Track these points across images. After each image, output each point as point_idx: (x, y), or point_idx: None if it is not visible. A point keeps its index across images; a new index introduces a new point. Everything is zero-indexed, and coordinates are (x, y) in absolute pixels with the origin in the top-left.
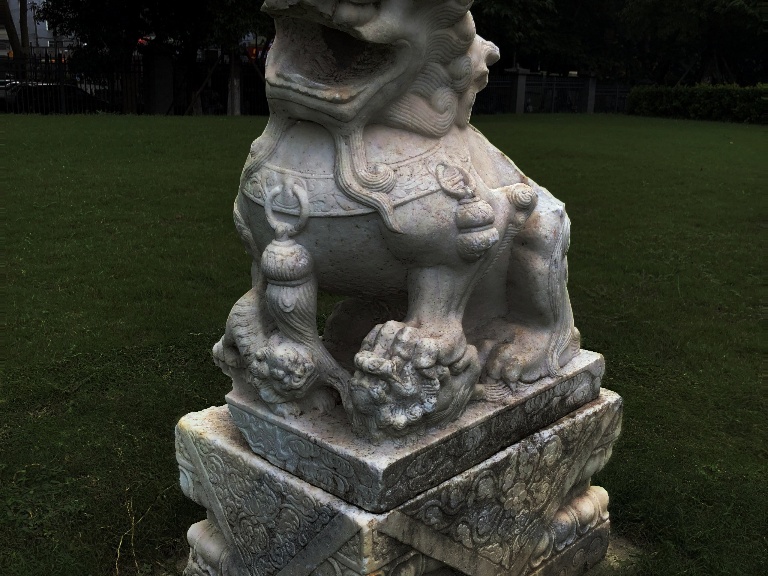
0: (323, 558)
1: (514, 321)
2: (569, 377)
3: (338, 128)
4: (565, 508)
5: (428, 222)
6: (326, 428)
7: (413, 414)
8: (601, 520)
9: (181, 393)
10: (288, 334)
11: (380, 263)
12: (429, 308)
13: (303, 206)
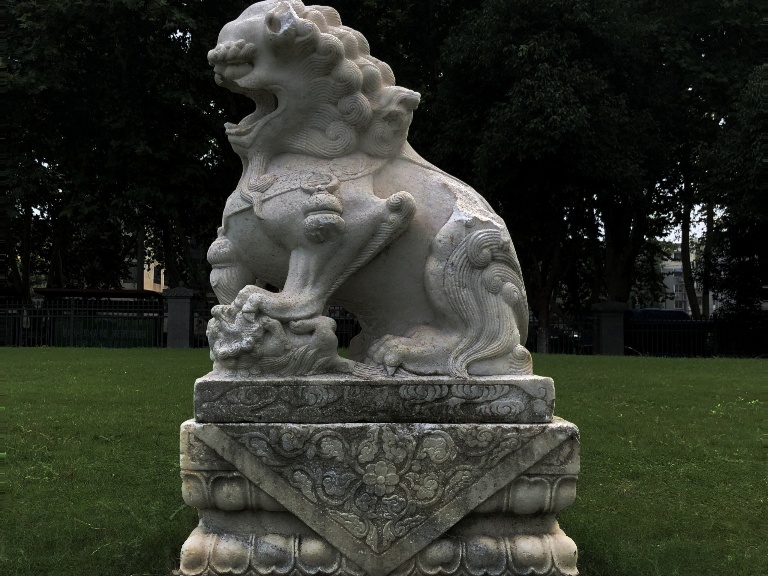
0: None
1: (431, 325)
2: (479, 383)
3: (247, 154)
4: (500, 538)
5: (281, 210)
6: None
7: (231, 347)
8: (560, 573)
9: None
10: None
11: (269, 250)
12: (290, 281)
13: (225, 210)
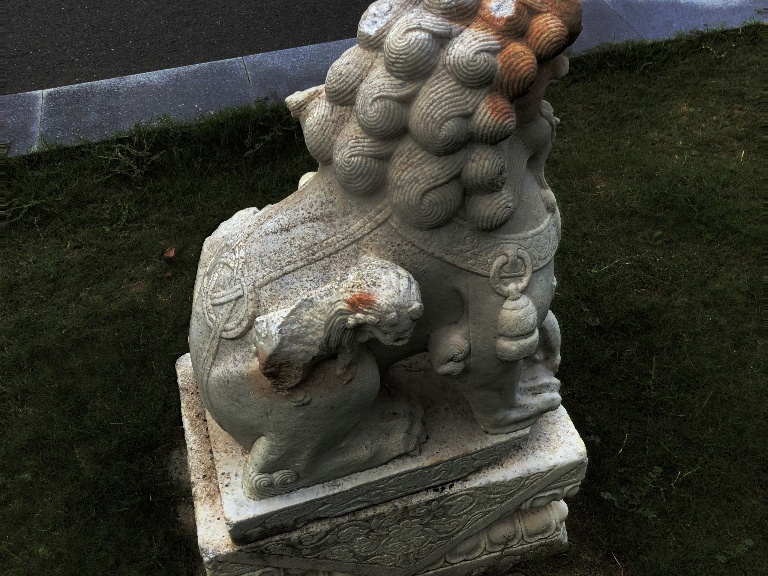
0: None
1: None
2: None
3: None
4: None
5: None
6: None
7: None
8: None
9: None
10: None
11: None
12: None
13: None
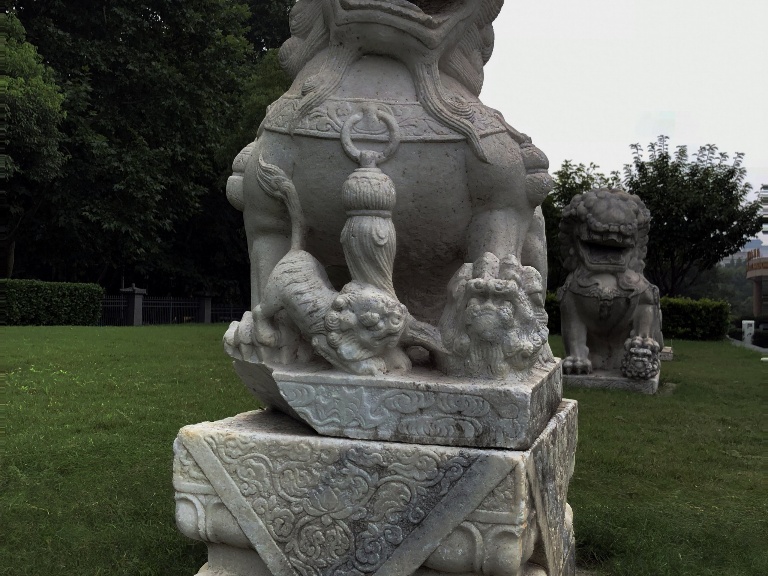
0: (453, 526)
1: None
2: None
3: (421, 56)
4: None
5: (507, 156)
6: (427, 378)
7: (536, 339)
8: None
9: (5, 509)
10: (371, 277)
11: (456, 202)
12: (503, 251)
13: (395, 129)
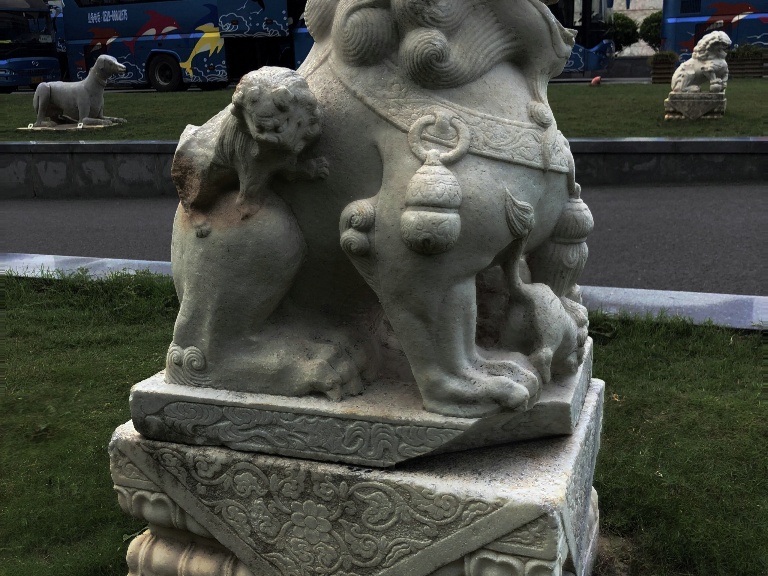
0: None
1: None
2: None
3: None
4: None
5: None
6: None
7: None
8: None
9: None
10: None
11: None
12: None
13: None
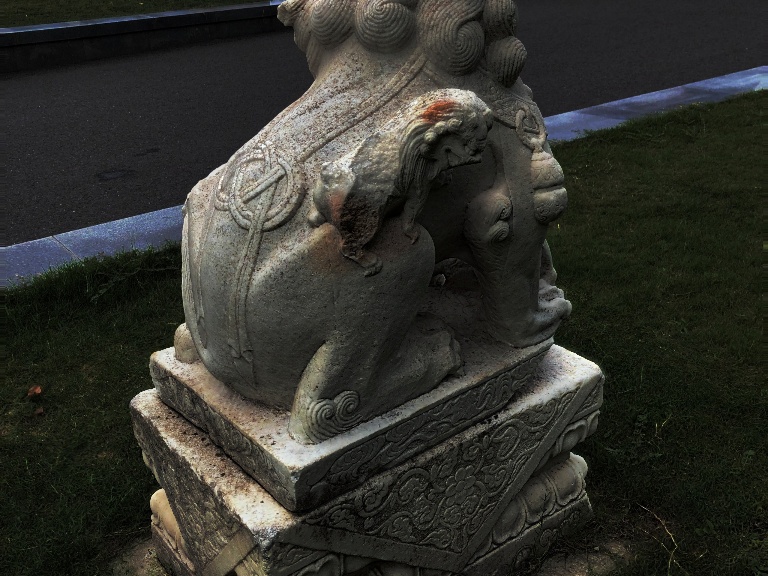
0: None
1: None
2: None
3: None
4: None
5: None
6: None
7: None
8: None
9: None
10: None
11: None
12: None
13: None
